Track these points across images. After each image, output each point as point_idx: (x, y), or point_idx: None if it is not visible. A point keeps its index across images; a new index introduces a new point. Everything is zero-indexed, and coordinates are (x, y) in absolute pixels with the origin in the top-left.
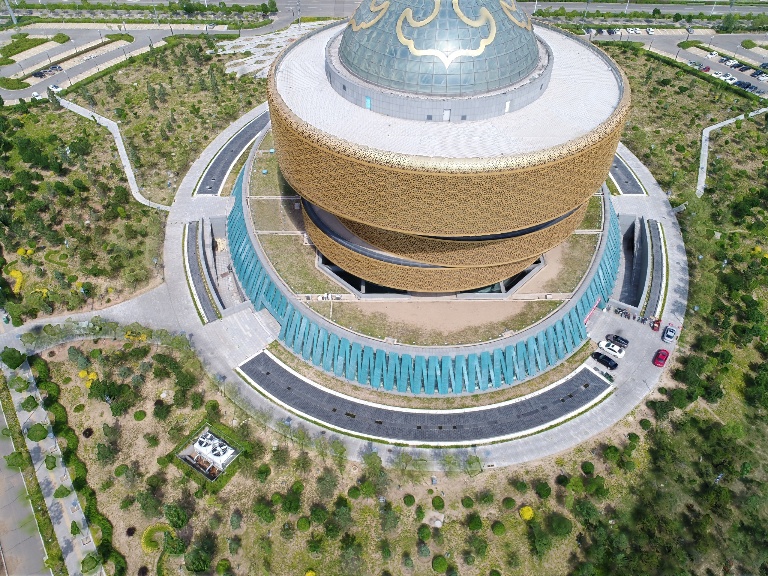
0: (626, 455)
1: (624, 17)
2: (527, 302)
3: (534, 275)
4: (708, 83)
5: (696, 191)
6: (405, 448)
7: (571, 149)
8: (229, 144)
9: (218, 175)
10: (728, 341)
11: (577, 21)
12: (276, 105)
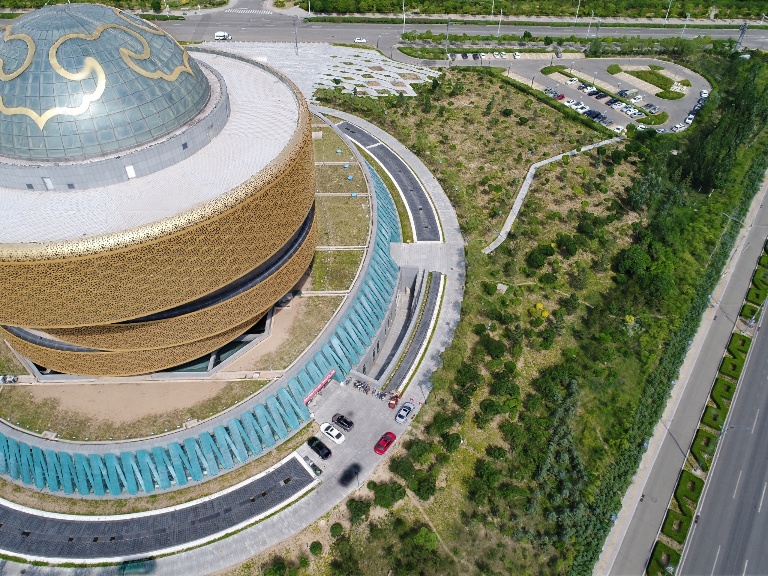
0: (299, 572)
1: (497, 40)
2: (229, 382)
3: (251, 348)
4: (558, 112)
5: (498, 237)
6: (42, 568)
7: (165, 228)
8: None
9: None
10: (470, 420)
11: (447, 44)
12: None
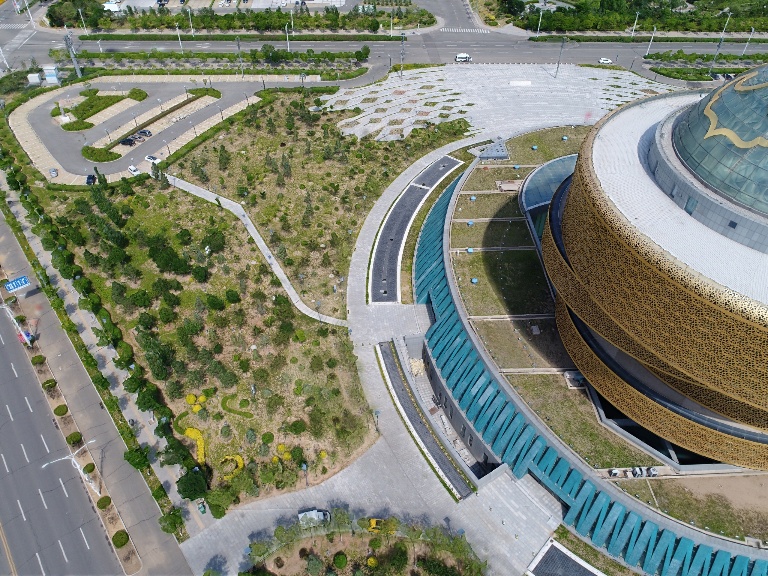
0: None
1: None
2: None
3: None
4: None
5: None
6: None
7: None
8: (384, 230)
9: (388, 274)
10: None
11: (694, 64)
12: (653, 254)
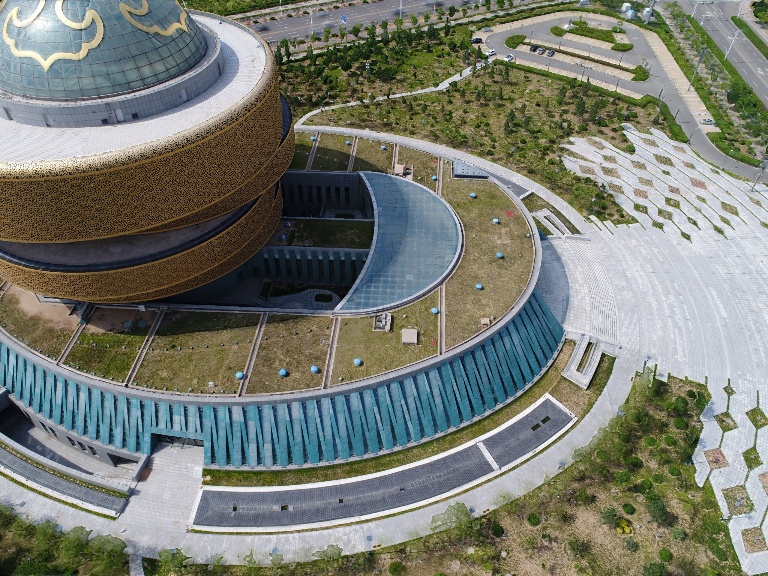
0: None
1: None
2: (3, 279)
3: None
4: None
5: None
6: None
7: None
8: None
9: None
10: None
11: None
12: None
